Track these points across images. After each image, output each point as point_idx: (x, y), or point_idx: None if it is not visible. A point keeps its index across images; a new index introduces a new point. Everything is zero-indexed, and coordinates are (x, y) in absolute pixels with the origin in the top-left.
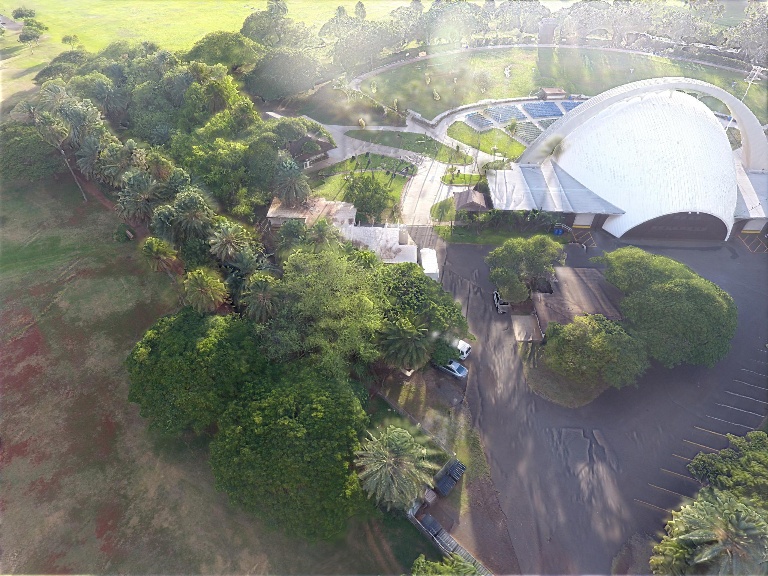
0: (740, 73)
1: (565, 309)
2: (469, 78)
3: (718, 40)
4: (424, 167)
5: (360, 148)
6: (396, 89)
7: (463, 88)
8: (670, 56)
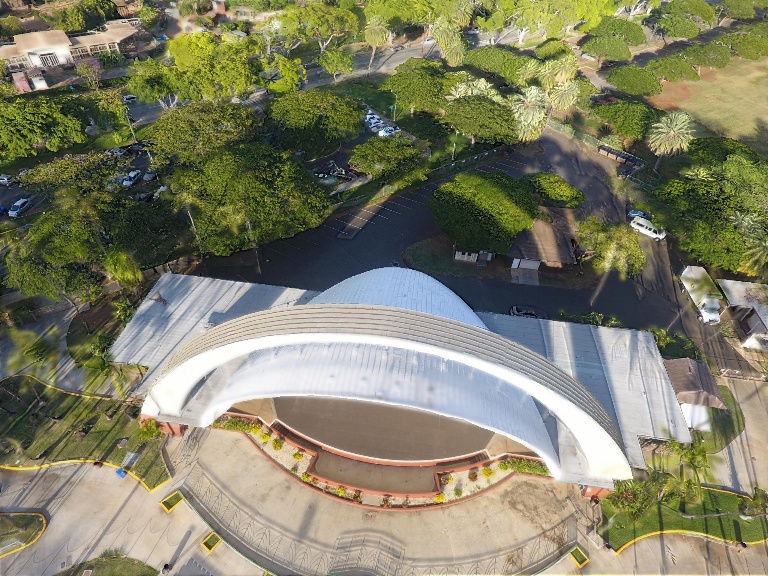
0: None
1: (563, 222)
2: None
3: None
4: None
5: None
6: None
7: None
8: None
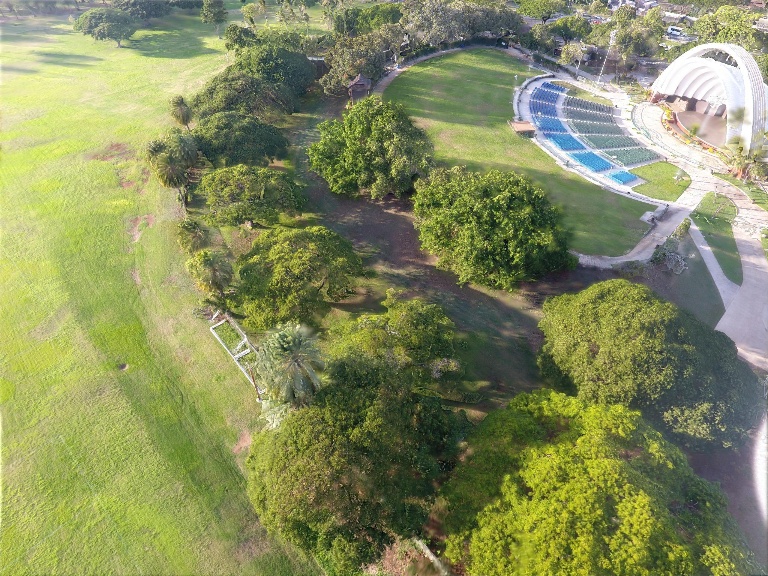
0: (449, 54)
1: None
2: (504, 167)
3: (334, 43)
4: (761, 223)
5: (765, 270)
6: (586, 224)
7: (539, 175)
8: (406, 64)
